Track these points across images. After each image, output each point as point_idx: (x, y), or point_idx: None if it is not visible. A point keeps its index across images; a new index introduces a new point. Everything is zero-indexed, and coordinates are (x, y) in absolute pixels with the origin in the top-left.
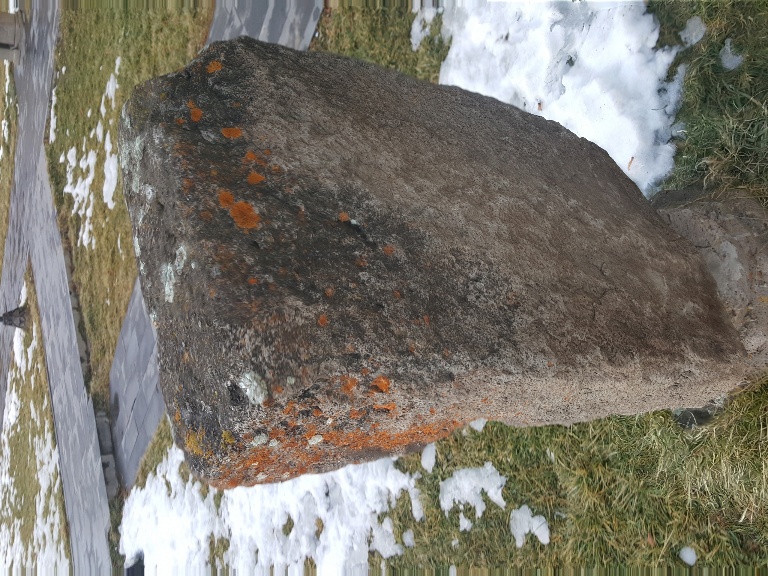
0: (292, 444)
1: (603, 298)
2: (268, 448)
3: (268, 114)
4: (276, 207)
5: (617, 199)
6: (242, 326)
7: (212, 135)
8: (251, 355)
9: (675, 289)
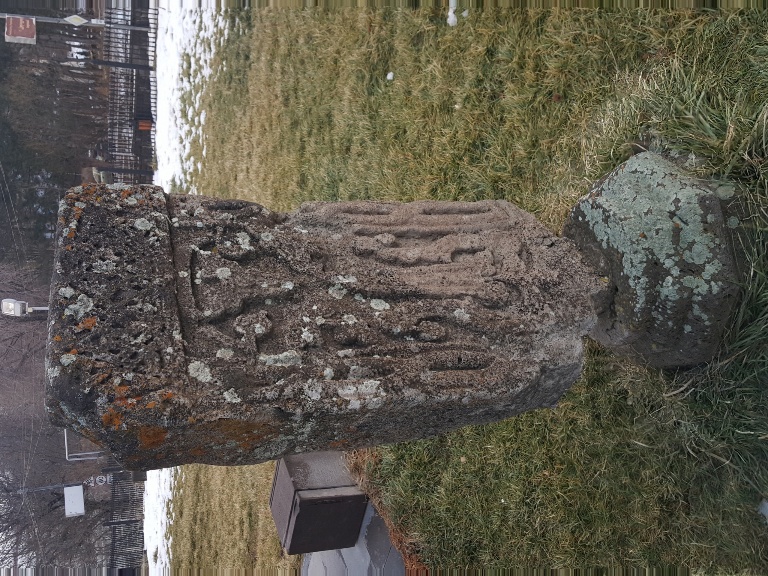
0: None
1: None
2: None
3: None
4: None
5: None
6: None
7: None
8: None
9: None
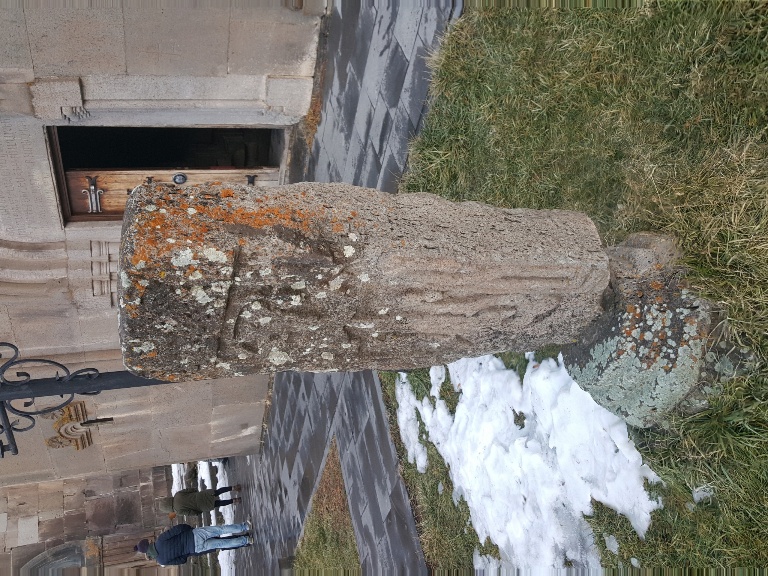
0: (176, 213)
1: None
2: (161, 214)
3: None
4: None
5: None
6: None
7: None
8: None
9: None
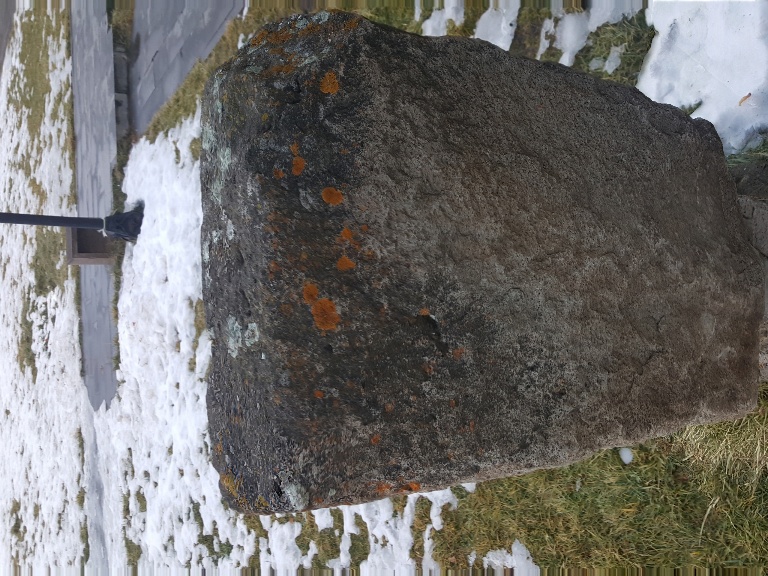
0: None
1: (647, 365)
2: None
3: (377, 170)
4: (360, 304)
5: (708, 218)
6: (300, 443)
7: (311, 199)
8: (302, 470)
9: (721, 332)
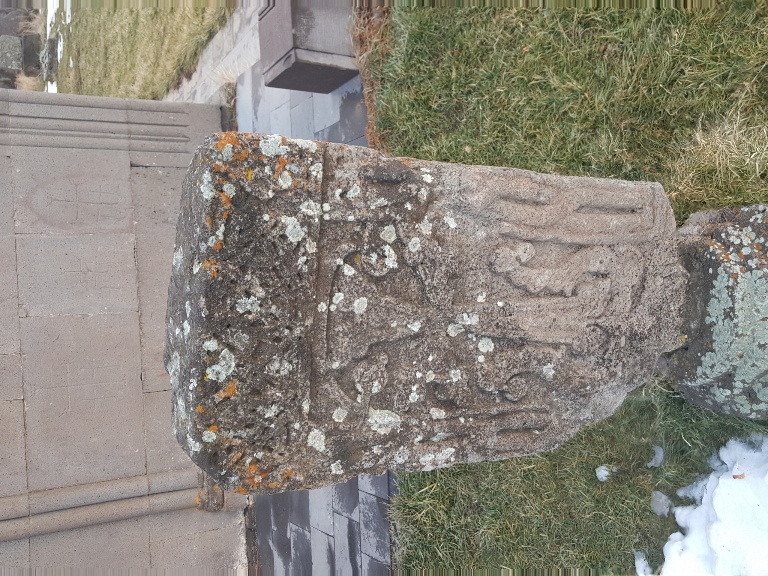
0: None
1: None
2: None
3: None
4: None
5: None
6: None
7: None
8: None
9: None
